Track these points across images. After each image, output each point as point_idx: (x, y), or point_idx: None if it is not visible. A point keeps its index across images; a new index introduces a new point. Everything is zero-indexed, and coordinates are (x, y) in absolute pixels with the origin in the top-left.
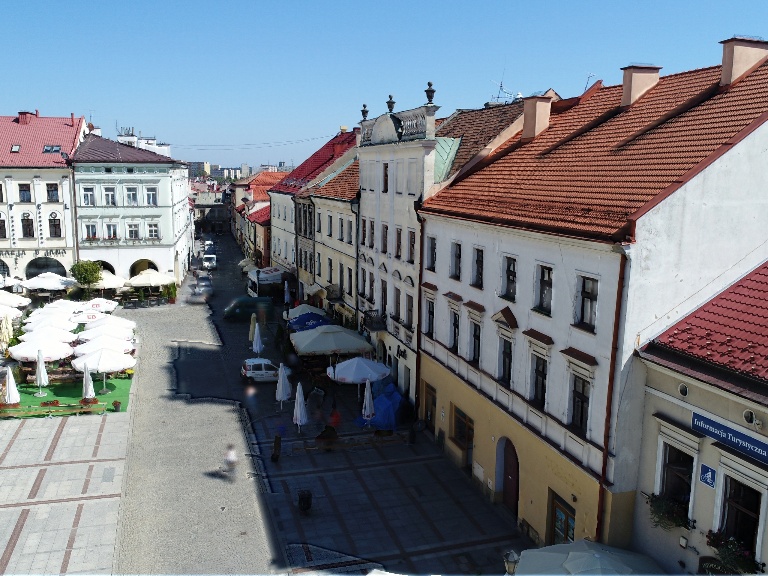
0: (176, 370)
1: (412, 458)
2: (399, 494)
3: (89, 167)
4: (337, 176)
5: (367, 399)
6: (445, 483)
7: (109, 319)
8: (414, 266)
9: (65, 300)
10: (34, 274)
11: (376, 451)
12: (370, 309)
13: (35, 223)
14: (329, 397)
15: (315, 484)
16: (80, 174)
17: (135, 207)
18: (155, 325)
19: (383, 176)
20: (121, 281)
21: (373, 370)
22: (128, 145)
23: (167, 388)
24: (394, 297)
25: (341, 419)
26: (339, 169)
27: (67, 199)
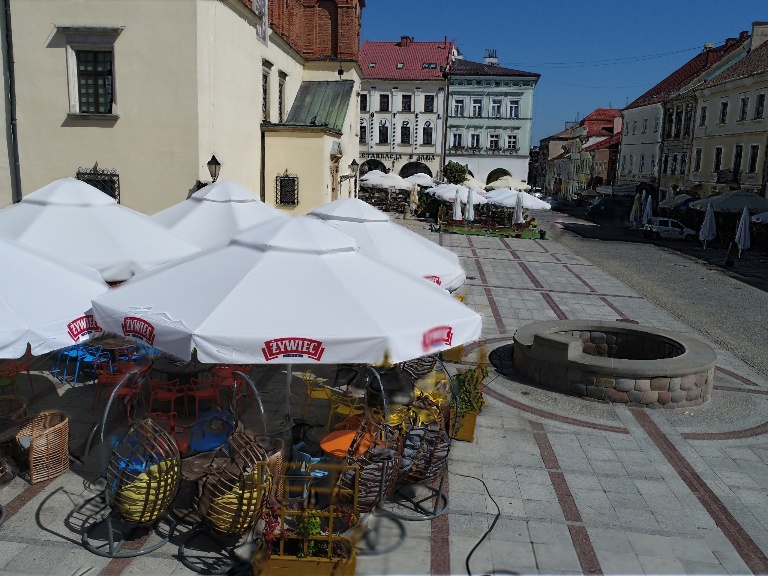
0: (571, 231)
1: None
2: None
3: (462, 80)
4: (727, 69)
5: None
6: None
7: None
8: None
9: None
10: None
11: None
12: None
13: (412, 130)
14: (747, 250)
15: None
16: (454, 86)
17: (498, 118)
18: None
19: None
20: (482, 184)
21: None
22: None
23: (574, 236)
24: None
25: None
26: (729, 63)
27: (441, 109)
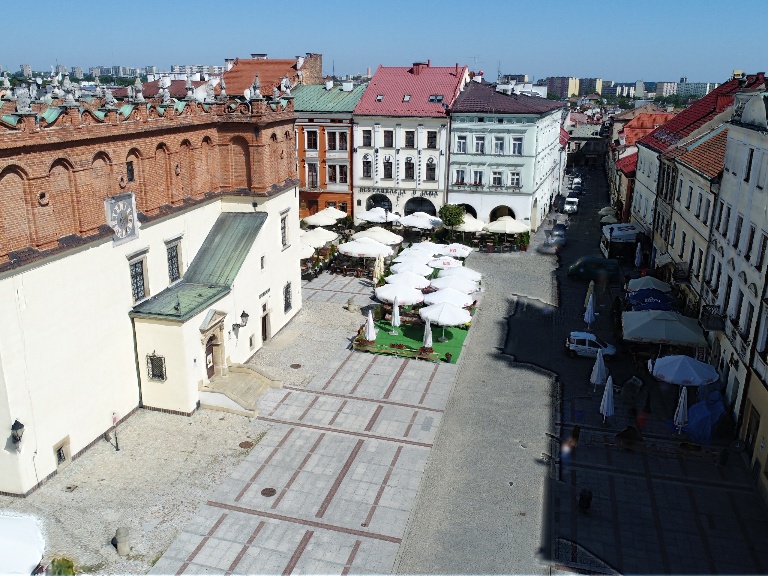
0: (508, 327)
1: (716, 482)
2: (687, 519)
3: (465, 117)
4: (709, 140)
5: (681, 406)
6: (745, 521)
7: (459, 269)
8: (761, 275)
9: (429, 242)
10: (411, 211)
11: (679, 463)
12: (713, 301)
13: (415, 166)
14: (648, 388)
15: (603, 483)
16: (456, 123)
17: (501, 156)
18: (502, 274)
19: (747, 162)
20: (480, 225)
21: (698, 373)
22: (503, 93)
23: (496, 346)
24: (737, 299)
25: (653, 417)
26: (713, 132)
27: (443, 146)
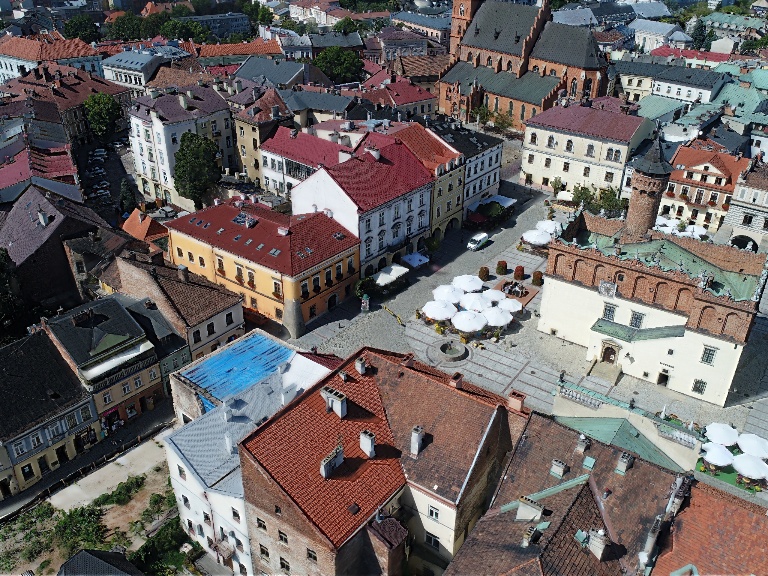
0: None
1: None
2: None
3: None
4: None
5: None
6: None
7: None
8: None
9: None
10: None
11: None
12: None
13: None
14: None
15: None
16: None
17: None
18: None
19: None
20: None
21: None
22: None
23: None
24: None
25: None
26: None
27: None
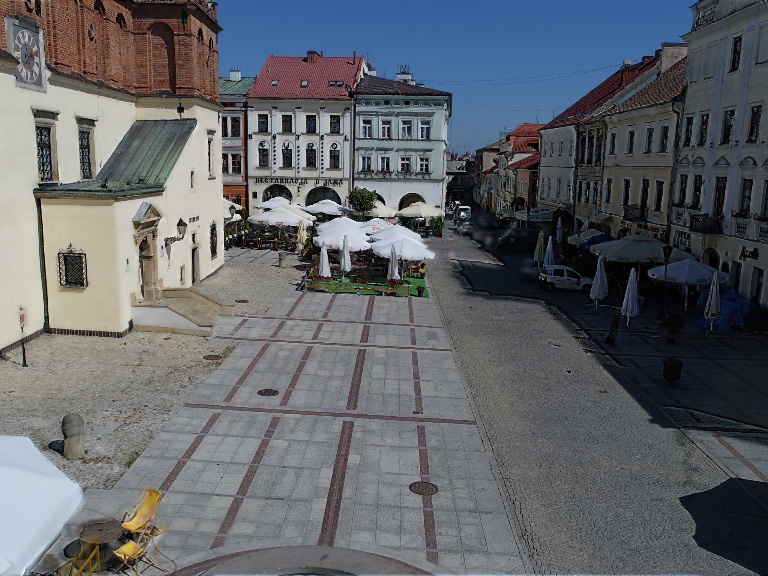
0: (465, 277)
1: None
2: None
3: (369, 99)
4: (636, 93)
5: (713, 294)
6: None
7: (396, 227)
8: None
9: (347, 218)
10: (313, 203)
11: (731, 348)
12: None
13: (318, 153)
14: (645, 306)
15: None
16: (361, 106)
17: (409, 140)
18: None
19: (731, 53)
20: (392, 211)
21: (710, 272)
22: None
23: (462, 287)
24: (740, 191)
25: None
26: (638, 86)
27: (347, 131)
